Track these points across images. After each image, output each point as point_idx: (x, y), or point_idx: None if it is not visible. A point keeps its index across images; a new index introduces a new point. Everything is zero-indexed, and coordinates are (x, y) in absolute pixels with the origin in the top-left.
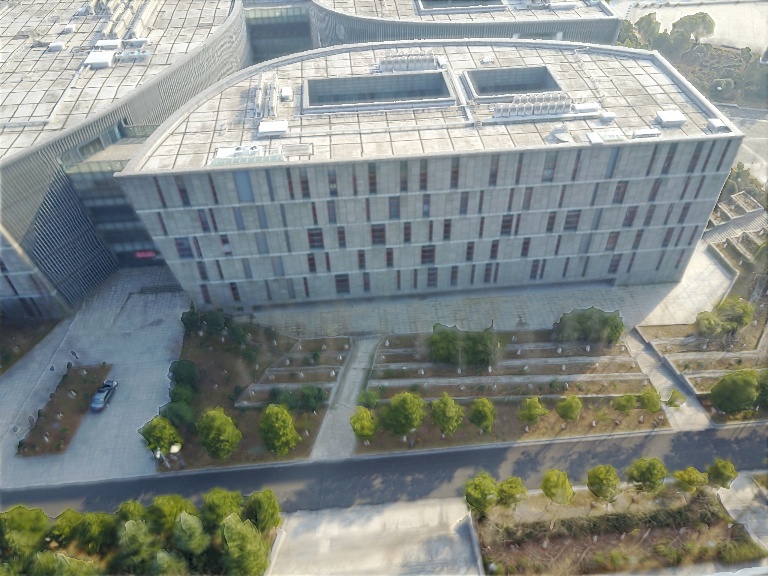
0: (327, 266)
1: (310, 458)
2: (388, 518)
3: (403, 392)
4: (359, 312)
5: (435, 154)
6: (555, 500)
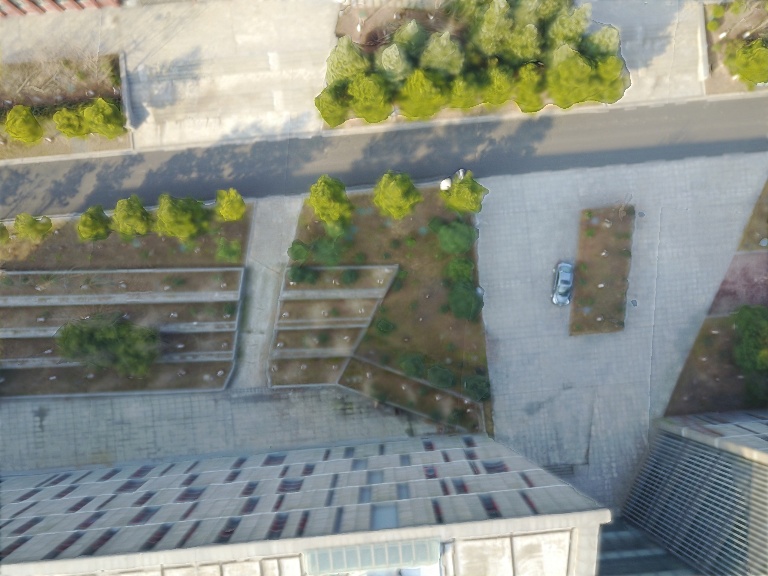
0: (287, 470)
1: (304, 199)
2: (217, 128)
3: (196, 281)
4: (262, 439)
5: (19, 568)
6: (26, 107)
